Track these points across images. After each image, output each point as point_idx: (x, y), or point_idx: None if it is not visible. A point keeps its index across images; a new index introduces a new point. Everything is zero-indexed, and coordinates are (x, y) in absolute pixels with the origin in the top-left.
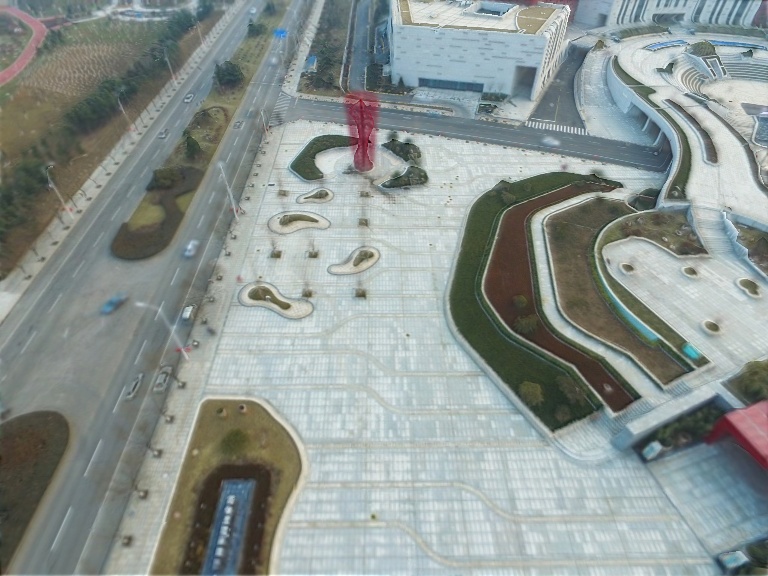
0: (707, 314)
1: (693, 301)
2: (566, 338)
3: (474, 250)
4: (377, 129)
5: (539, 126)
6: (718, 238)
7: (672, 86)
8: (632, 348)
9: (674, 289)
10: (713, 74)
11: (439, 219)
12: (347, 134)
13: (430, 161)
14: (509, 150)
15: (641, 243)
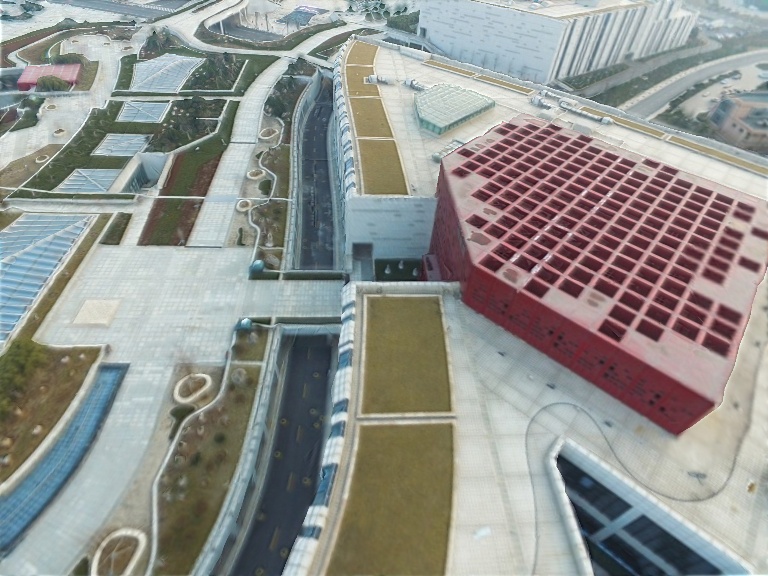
0: (89, 54)
1: (90, 51)
2: (8, 59)
3: (14, 40)
4: None
5: None
6: (142, 35)
7: None
8: (33, 61)
9: (88, 48)
10: None
11: (14, 32)
12: (5, 0)
13: (45, 13)
14: (106, 13)
15: (101, 37)
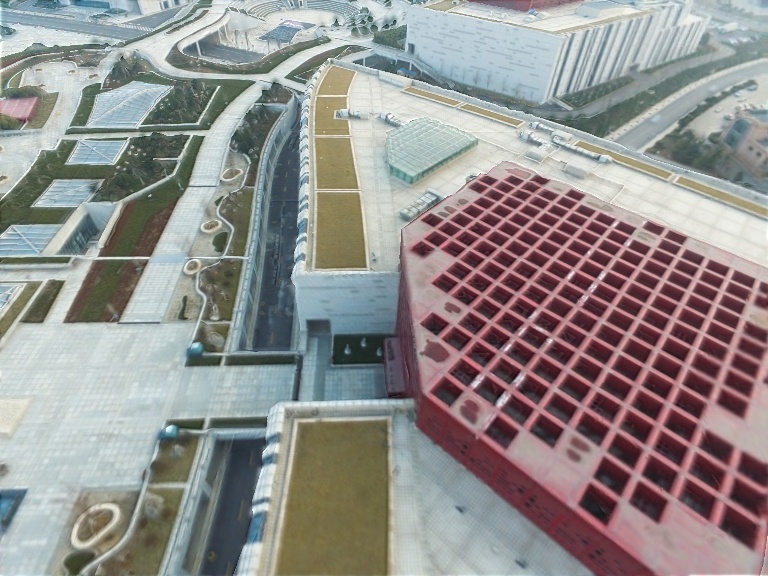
0: (51, 84)
1: None
2: None
3: None
4: (2, 22)
5: (124, 26)
6: (111, 61)
7: (227, 5)
8: None
9: (51, 77)
10: (291, 5)
11: None
12: None
13: (15, 37)
14: (79, 35)
15: None
